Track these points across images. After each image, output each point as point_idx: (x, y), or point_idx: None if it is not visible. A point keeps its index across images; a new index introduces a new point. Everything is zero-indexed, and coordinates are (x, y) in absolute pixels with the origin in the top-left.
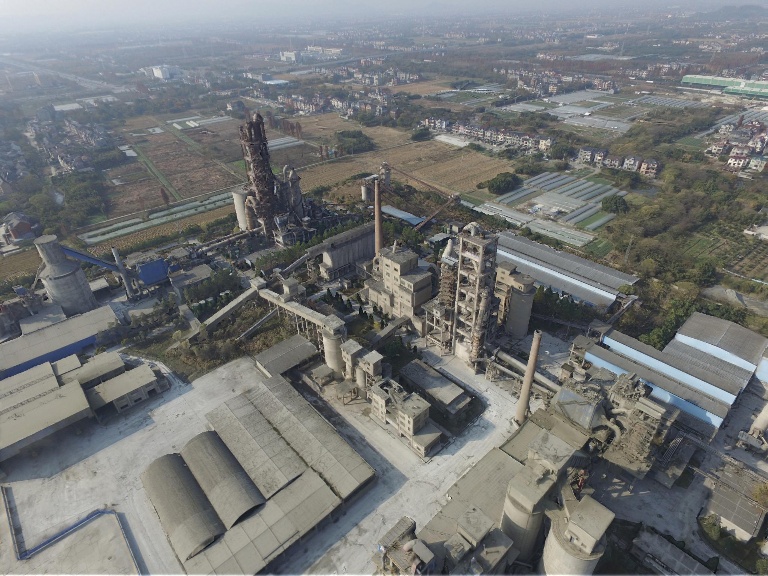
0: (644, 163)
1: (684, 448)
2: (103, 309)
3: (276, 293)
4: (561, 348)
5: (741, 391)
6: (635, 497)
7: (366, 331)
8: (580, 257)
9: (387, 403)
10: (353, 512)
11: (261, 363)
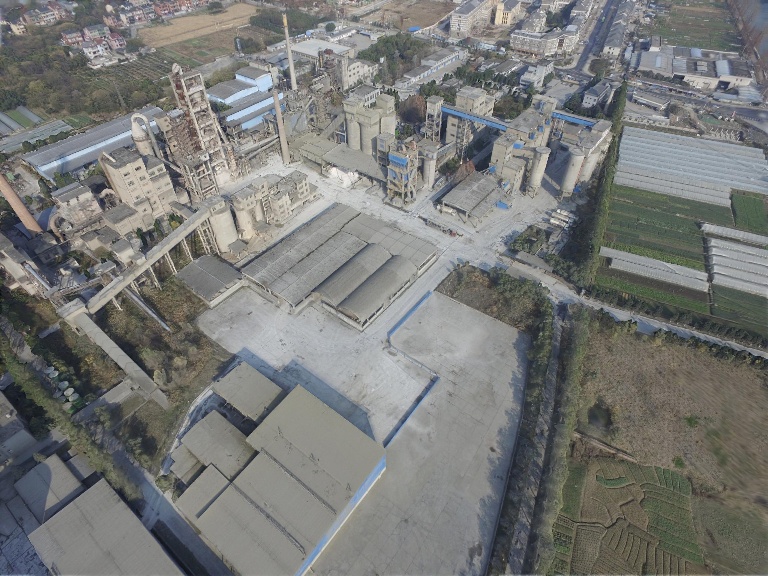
0: None
1: None
2: (43, 536)
3: (112, 281)
4: None
5: None
6: None
7: None
8: (104, 123)
9: (288, 194)
10: None
11: None
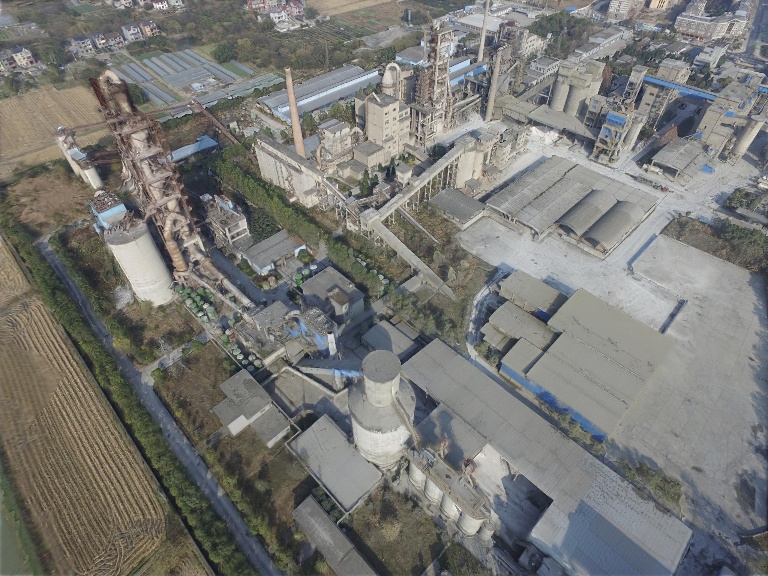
0: (146, 26)
1: None
2: (411, 369)
3: (394, 197)
4: None
5: None
6: None
7: None
8: (315, 77)
9: None
10: None
11: None
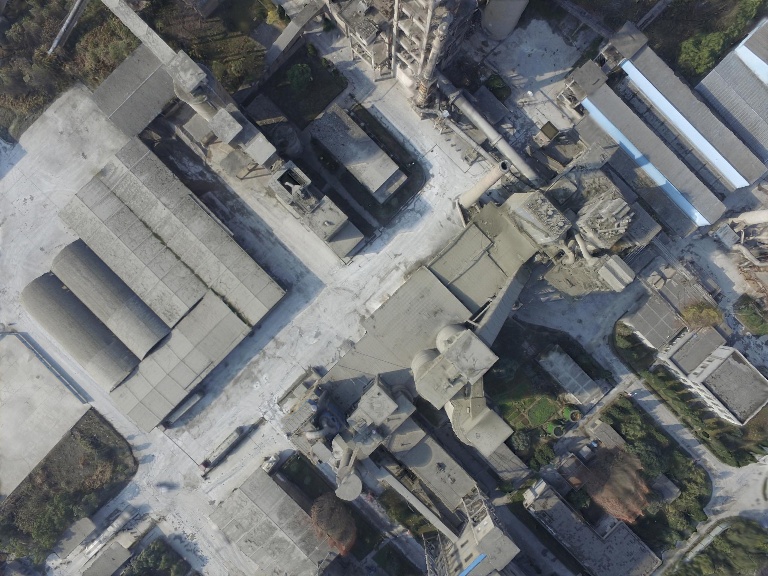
0: None
1: (643, 254)
2: None
3: None
4: (558, 60)
5: (765, 160)
6: (564, 301)
7: (257, 22)
8: None
9: None
10: (268, 325)
11: (104, 112)
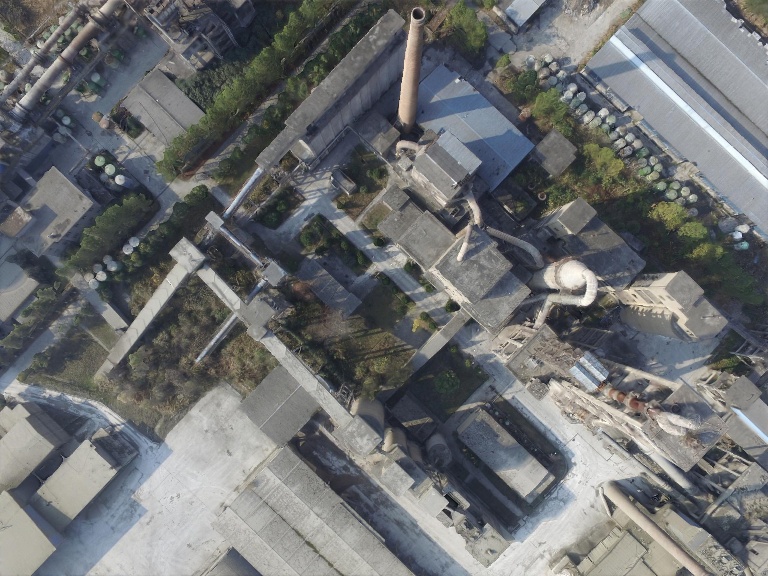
0: None
1: None
2: None
3: (234, 295)
4: (697, 348)
5: None
6: None
7: (398, 319)
8: None
9: None
10: None
11: (254, 422)
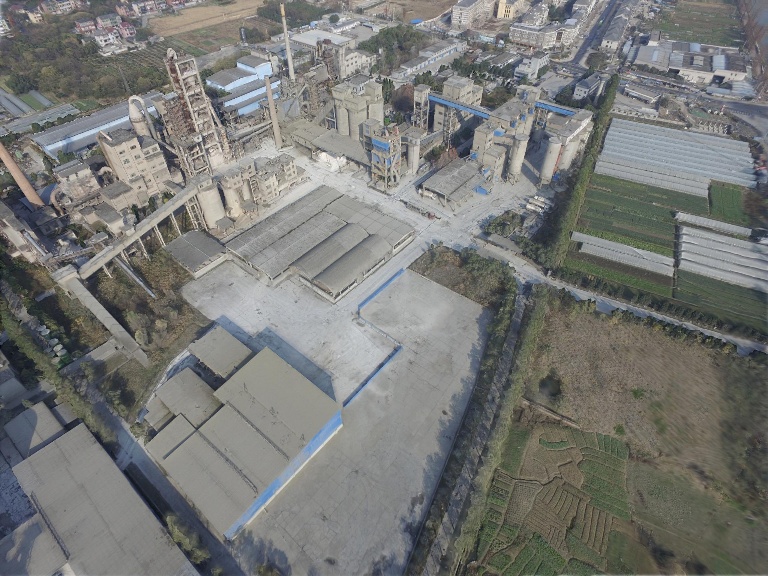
0: None
1: None
2: (25, 469)
3: (103, 250)
4: None
5: None
6: None
7: None
8: (109, 107)
9: None
10: None
11: None
